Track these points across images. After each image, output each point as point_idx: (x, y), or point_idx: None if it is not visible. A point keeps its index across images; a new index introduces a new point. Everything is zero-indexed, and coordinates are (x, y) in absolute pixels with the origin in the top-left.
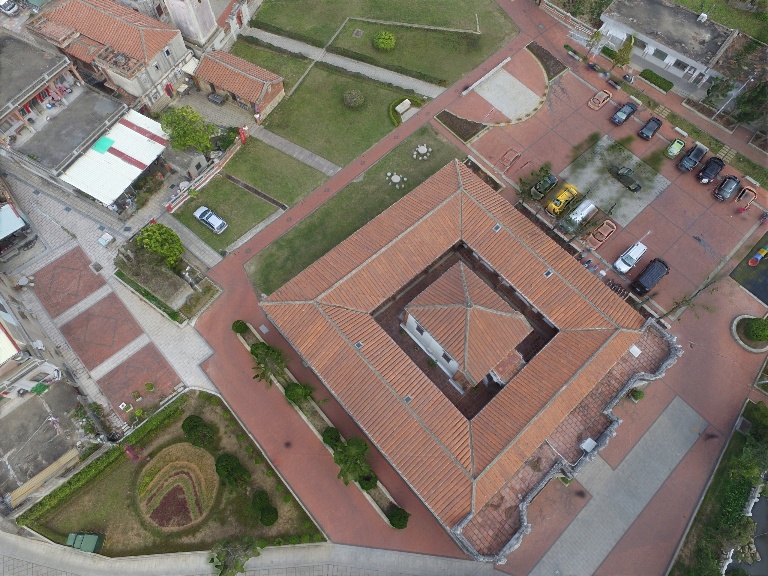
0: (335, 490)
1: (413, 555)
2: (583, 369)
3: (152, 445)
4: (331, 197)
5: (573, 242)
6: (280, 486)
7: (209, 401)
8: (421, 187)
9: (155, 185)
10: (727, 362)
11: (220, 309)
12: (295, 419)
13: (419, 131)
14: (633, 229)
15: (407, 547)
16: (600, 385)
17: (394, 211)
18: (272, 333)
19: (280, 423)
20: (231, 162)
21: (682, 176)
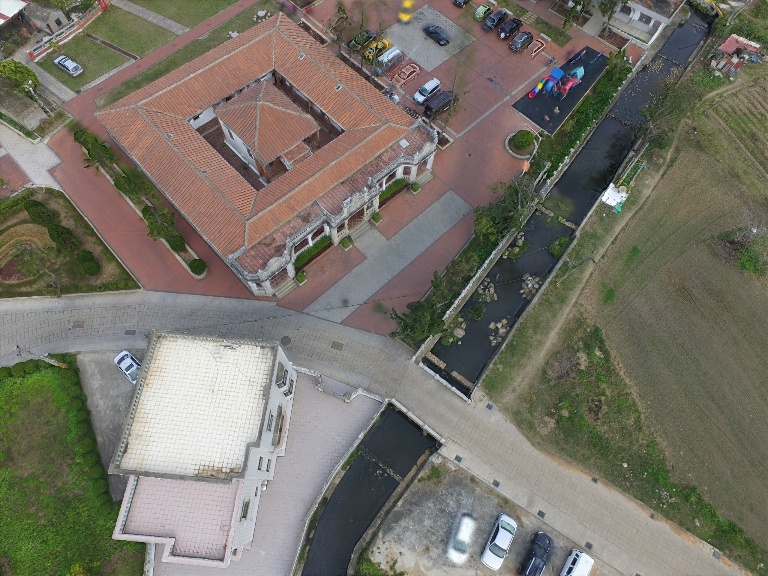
0: (153, 255)
1: (211, 297)
2: (352, 150)
3: (2, 227)
4: (178, 50)
5: (383, 82)
6: (105, 249)
7: (54, 196)
8: (246, 32)
9: (21, 39)
10: (497, 166)
11: (70, 131)
12: (125, 207)
13: (262, 1)
14: (437, 73)
15: (207, 292)
16: (370, 166)
17: (219, 48)
18: (113, 148)
19: (112, 210)
20: (92, 24)
21: (487, 34)
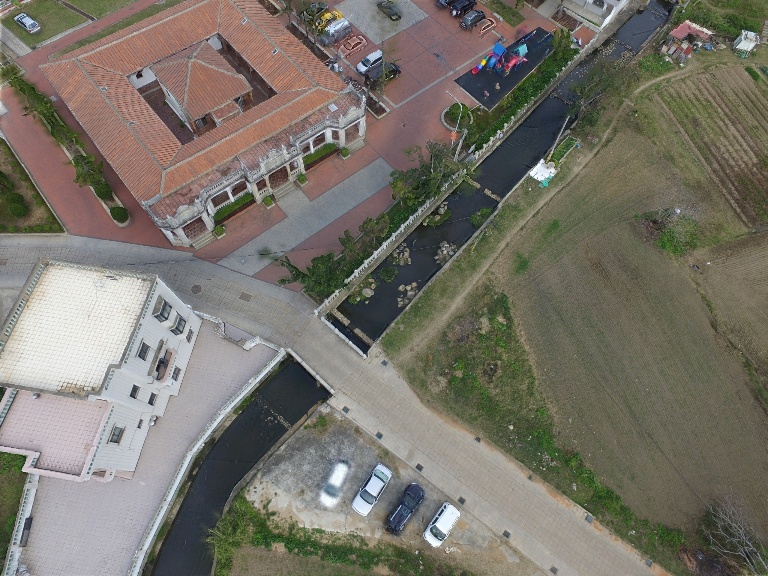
0: (81, 202)
1: (131, 245)
2: (278, 110)
3: None
4: (134, 13)
5: (329, 53)
6: (35, 194)
7: None
8: None
9: None
10: (430, 137)
11: None
12: (62, 157)
13: None
14: (384, 46)
15: (128, 240)
16: (295, 127)
17: (168, 11)
18: (59, 101)
19: (49, 159)
20: None
21: (440, 12)
